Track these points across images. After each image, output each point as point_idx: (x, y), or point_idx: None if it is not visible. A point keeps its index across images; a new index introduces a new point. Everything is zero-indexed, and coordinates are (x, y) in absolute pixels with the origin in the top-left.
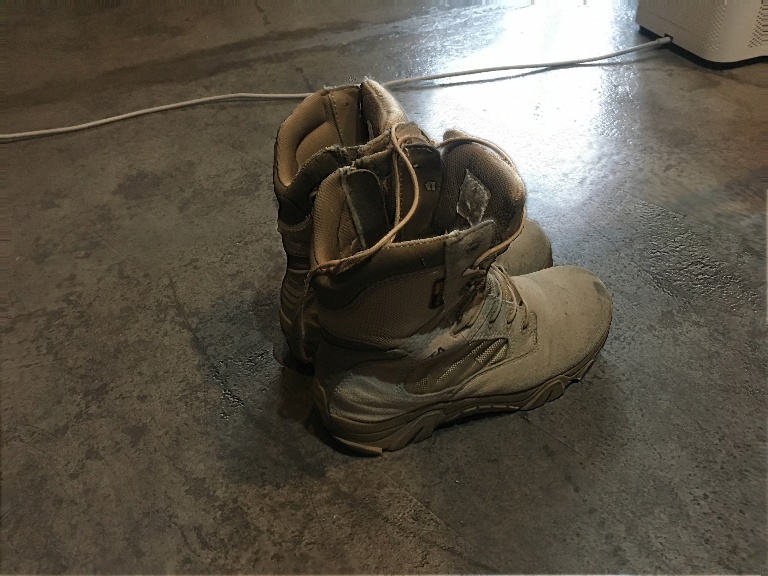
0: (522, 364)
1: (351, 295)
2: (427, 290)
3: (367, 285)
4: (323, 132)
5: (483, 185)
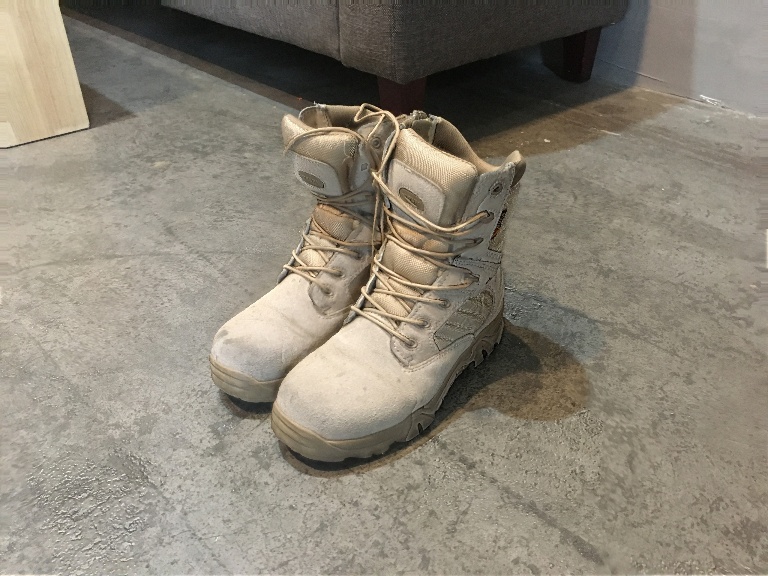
0: None
1: None
2: None
3: None
4: None
5: None
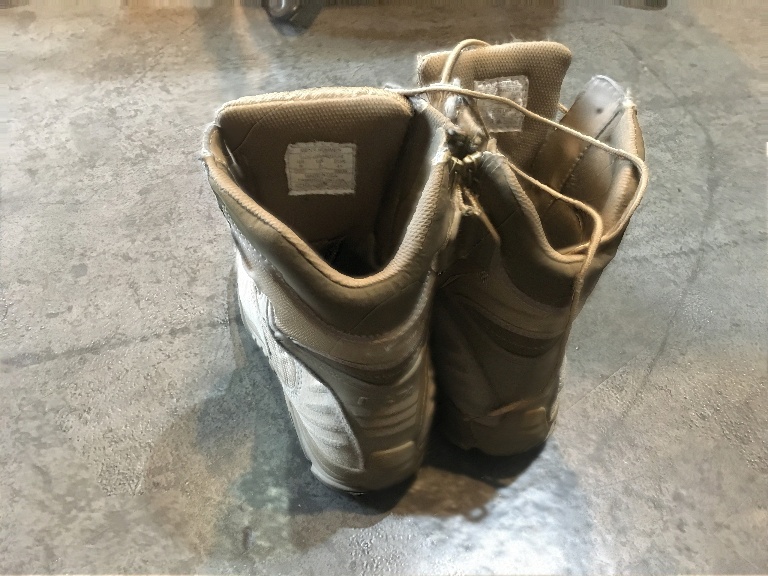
0: None
1: None
2: None
3: None
4: None
5: (510, 78)
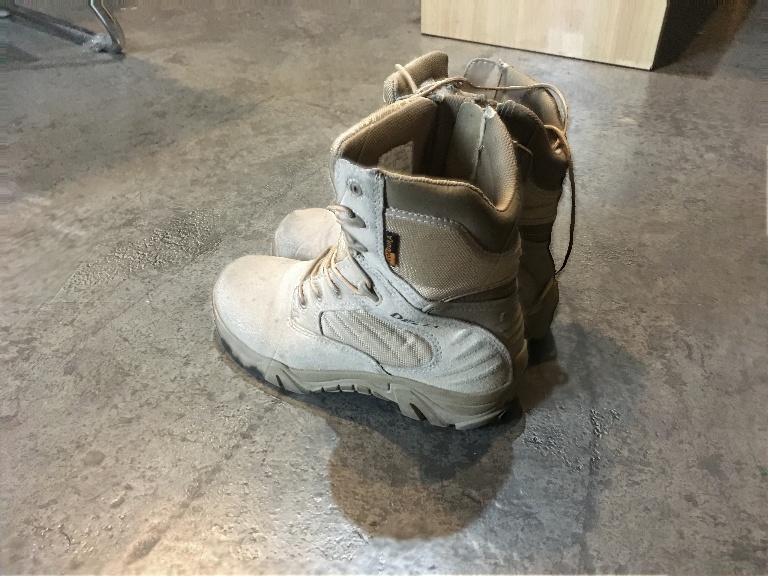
0: None
1: None
2: None
3: None
4: None
5: None
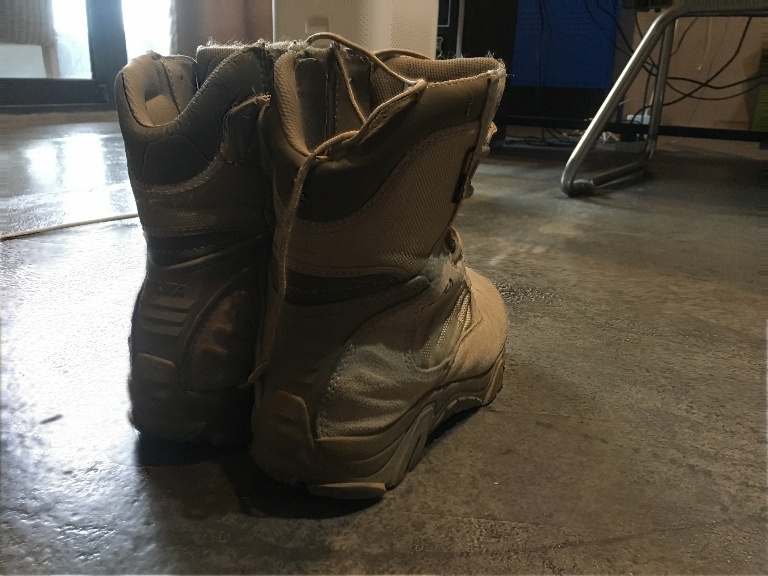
0: (483, 331)
1: (380, 175)
2: (457, 167)
3: (406, 150)
4: (160, 105)
5: None
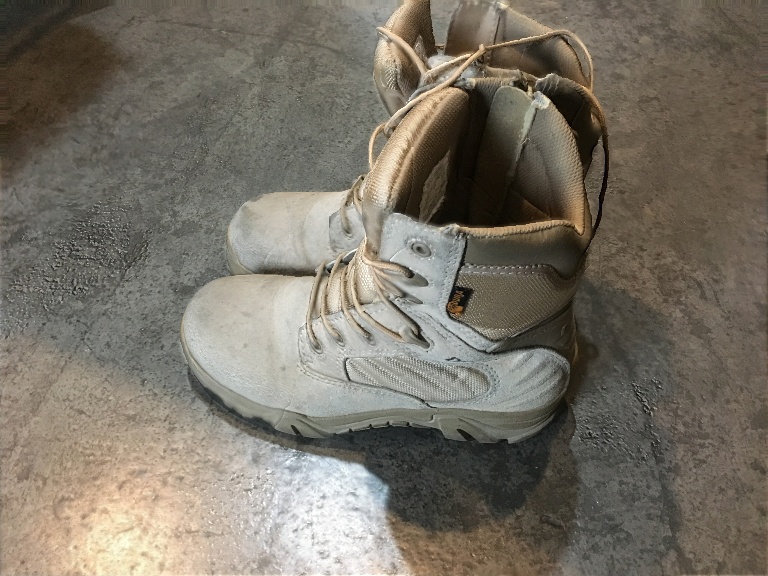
0: None
1: None
2: None
3: None
4: None
5: None
